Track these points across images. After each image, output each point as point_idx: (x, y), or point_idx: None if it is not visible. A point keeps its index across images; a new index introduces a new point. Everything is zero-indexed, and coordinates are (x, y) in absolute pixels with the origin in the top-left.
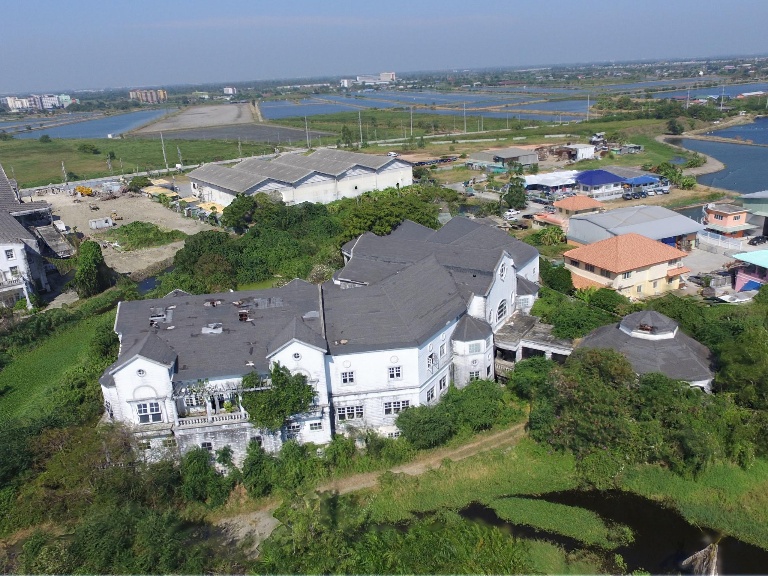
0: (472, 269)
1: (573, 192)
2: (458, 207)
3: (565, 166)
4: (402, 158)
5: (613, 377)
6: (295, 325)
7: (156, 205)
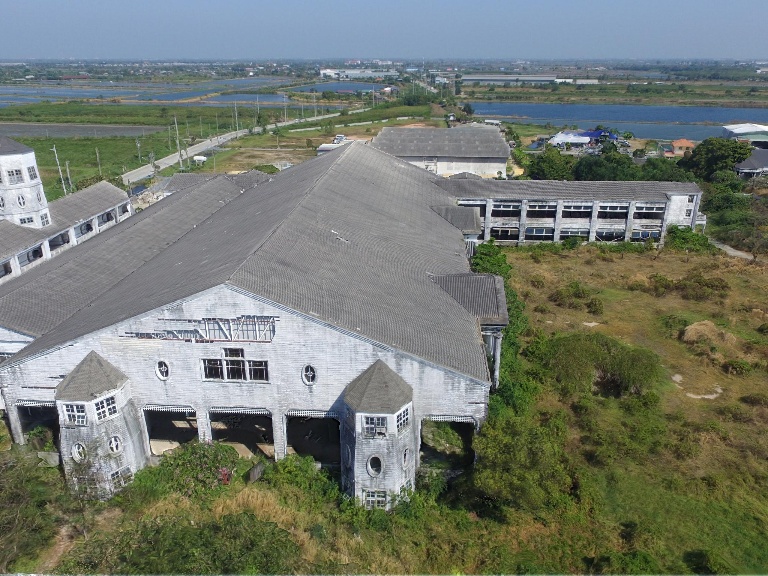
0: None
1: None
2: None
3: None
4: (359, 139)
5: None
6: None
7: None
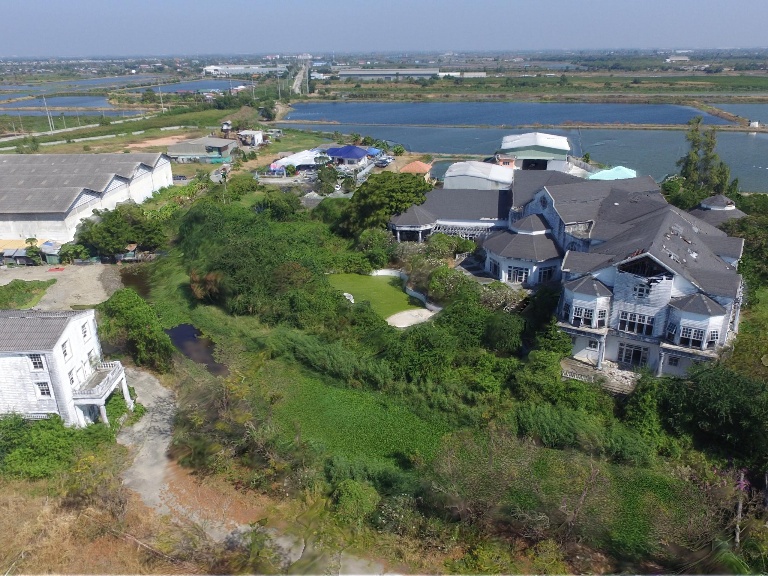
0: (646, 191)
1: (344, 166)
2: None
3: (261, 151)
4: None
5: (766, 227)
6: (715, 235)
7: None
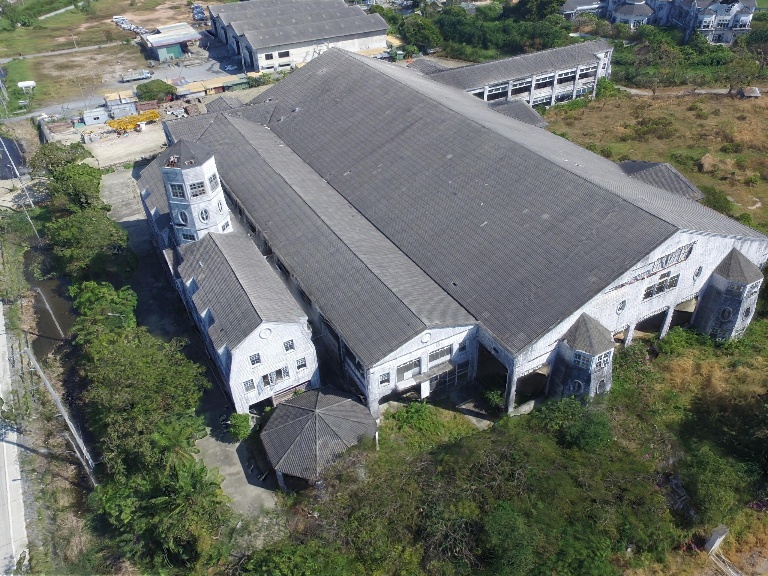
0: None
1: None
2: None
3: None
4: (143, 18)
5: None
6: None
7: None
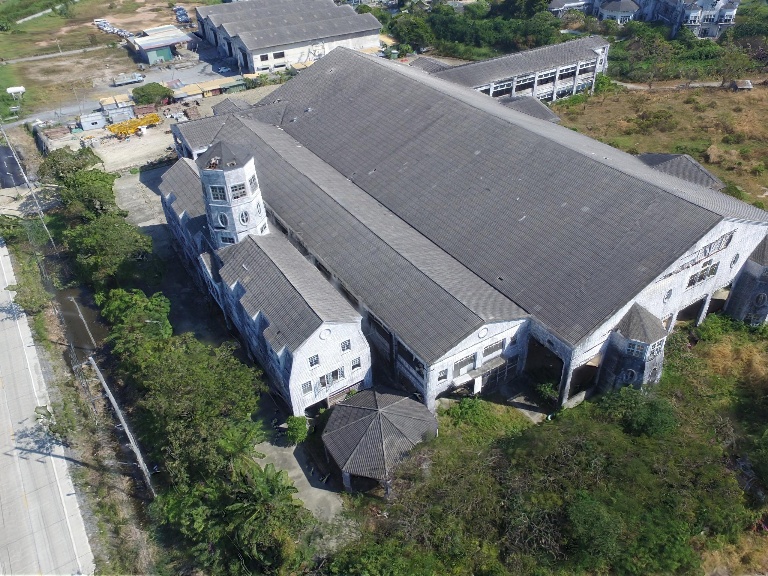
0: None
1: None
2: None
3: None
4: (125, 21)
5: None
6: None
7: (270, 87)
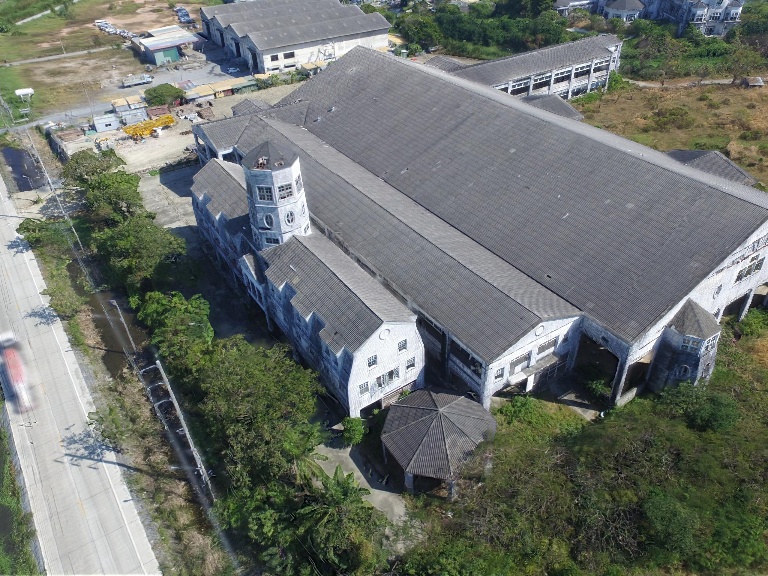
0: None
1: None
2: (422, 5)
3: None
4: (126, 22)
5: None
6: None
7: (282, 87)
